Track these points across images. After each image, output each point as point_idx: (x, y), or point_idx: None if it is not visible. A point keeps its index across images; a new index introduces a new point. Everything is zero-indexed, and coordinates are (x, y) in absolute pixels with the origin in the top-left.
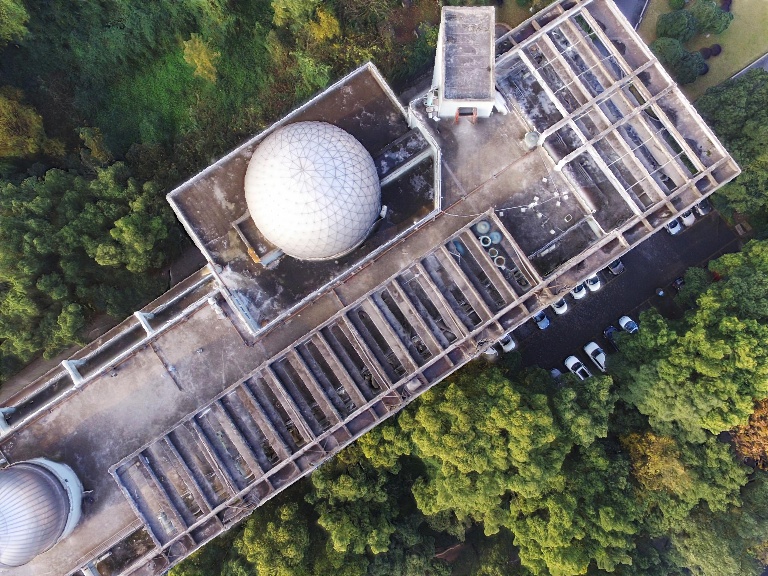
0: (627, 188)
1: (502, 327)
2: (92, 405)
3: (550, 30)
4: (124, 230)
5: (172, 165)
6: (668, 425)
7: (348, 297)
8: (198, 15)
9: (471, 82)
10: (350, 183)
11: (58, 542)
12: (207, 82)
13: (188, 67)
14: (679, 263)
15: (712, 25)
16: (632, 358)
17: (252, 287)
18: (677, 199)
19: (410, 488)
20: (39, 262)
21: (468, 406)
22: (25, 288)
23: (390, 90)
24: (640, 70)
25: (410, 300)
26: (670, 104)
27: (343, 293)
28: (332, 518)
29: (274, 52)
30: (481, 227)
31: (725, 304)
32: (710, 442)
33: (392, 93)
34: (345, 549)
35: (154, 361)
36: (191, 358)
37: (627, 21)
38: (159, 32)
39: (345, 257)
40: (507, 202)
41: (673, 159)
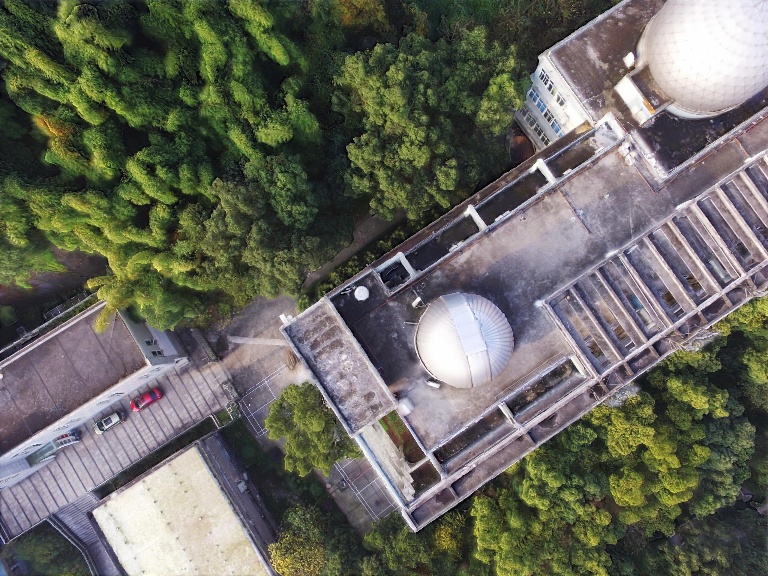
0: None
1: None
2: (502, 247)
3: None
4: (505, 86)
5: None
6: None
7: (750, 146)
8: None
9: None
10: None
11: None
12: None
13: None
14: None
15: None
16: None
17: None
18: None
19: (742, 358)
20: (427, 115)
21: None
22: (425, 136)
23: None
24: None
25: None
26: None
27: (745, 142)
28: None
29: None
30: None
31: None
32: None
33: None
34: (708, 406)
35: (561, 206)
36: (598, 203)
37: None
38: None
39: (721, 116)
40: None
41: None
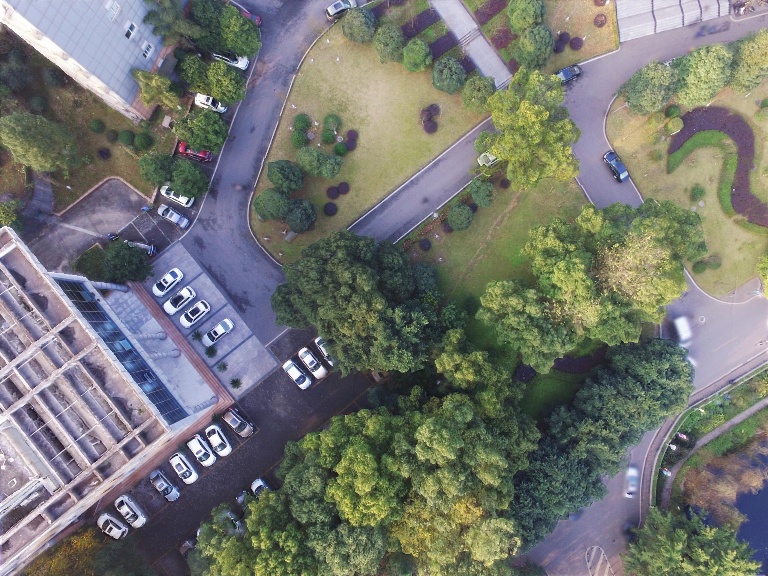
0: (52, 457)
1: None
2: None
3: None
4: None
5: None
6: None
7: None
8: None
9: None
10: None
11: None
12: None
13: None
14: (313, 418)
15: (321, 172)
16: (201, 560)
17: None
18: (107, 464)
19: None
20: None
21: None
22: None
23: None
24: (57, 329)
25: None
26: (98, 360)
27: None
28: None
29: None
30: None
31: (265, 512)
32: None
33: None
34: None
35: None
36: None
37: (42, 274)
38: None
39: None
40: None
41: (97, 424)
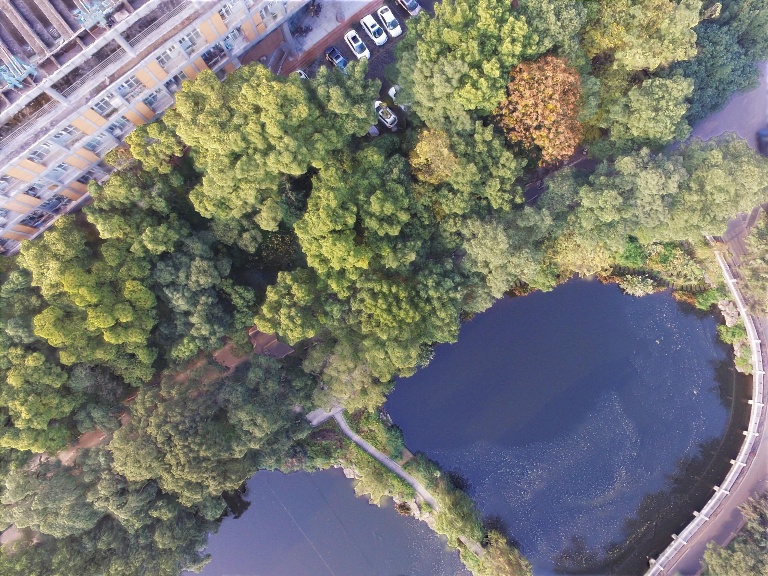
0: None
1: None
2: None
3: None
4: None
5: None
6: (440, 119)
7: None
8: None
9: None
10: None
11: None
12: None
13: None
14: None
15: None
16: None
17: None
18: None
19: (188, 194)
20: None
21: (222, 88)
22: None
23: None
24: None
25: None
26: None
27: None
28: (102, 216)
29: None
30: None
31: None
32: (477, 127)
33: None
34: (108, 233)
35: None
36: None
37: None
38: None
39: None
40: None
41: None
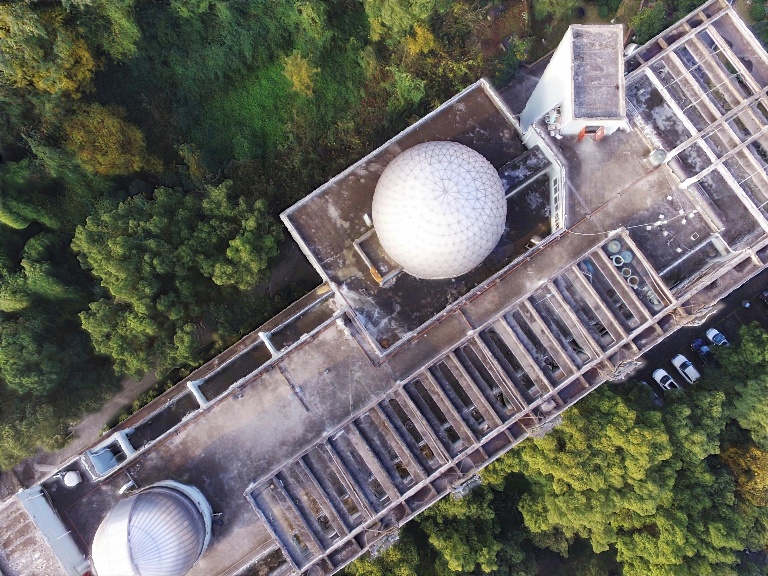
0: (758, 206)
1: (637, 347)
2: (219, 427)
3: (676, 48)
4: (240, 249)
5: (270, 181)
6: None
7: (474, 317)
8: (294, 31)
9: (600, 101)
10: (489, 204)
11: (193, 566)
12: (299, 97)
13: (281, 82)
14: (765, 275)
15: None
16: (736, 373)
17: (369, 306)
18: None
19: (516, 505)
20: (157, 282)
21: (582, 424)
22: (147, 309)
23: (503, 107)
24: None
25: (542, 320)
26: None
27: (469, 313)
28: (443, 536)
29: (367, 67)
30: (612, 246)
31: None
32: None
33: (505, 110)
34: (461, 568)
35: (280, 382)
36: (317, 379)
37: None
38: (256, 48)
39: (462, 275)
40: (632, 220)
41: None
